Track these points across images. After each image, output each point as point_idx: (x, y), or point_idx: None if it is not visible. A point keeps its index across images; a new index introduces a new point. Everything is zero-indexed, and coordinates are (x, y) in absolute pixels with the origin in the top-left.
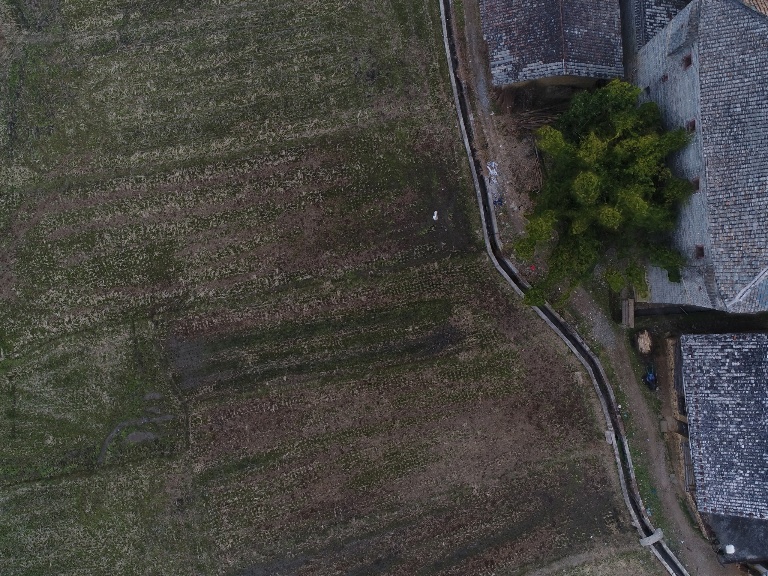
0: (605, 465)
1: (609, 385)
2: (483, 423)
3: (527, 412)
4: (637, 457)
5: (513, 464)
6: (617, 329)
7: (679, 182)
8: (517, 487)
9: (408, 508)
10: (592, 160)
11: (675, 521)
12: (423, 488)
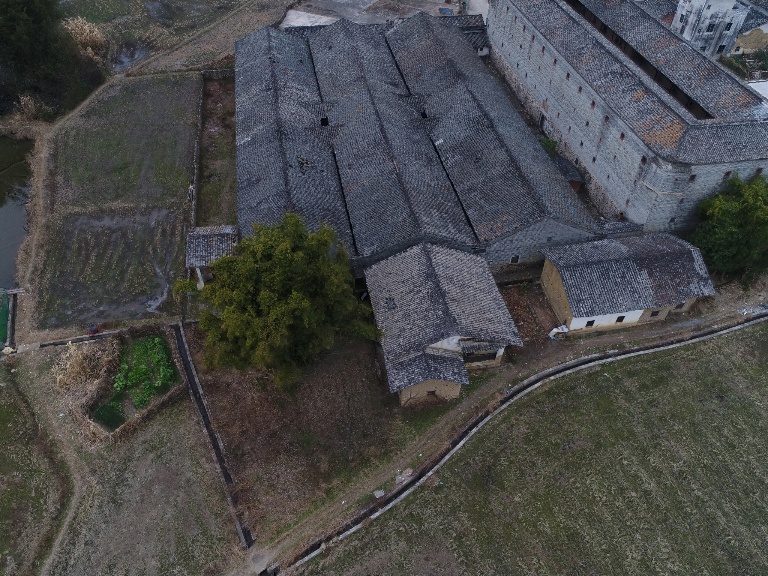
0: None
1: None
2: None
3: None
4: None
5: None
6: None
7: (757, 180)
8: None
9: None
10: None
11: None
12: None
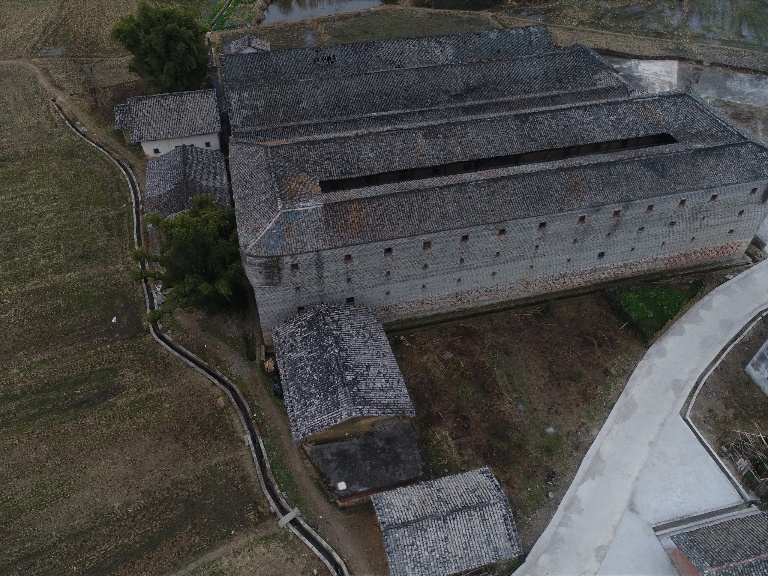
0: (244, 464)
1: (245, 401)
2: (133, 450)
3: (174, 435)
4: (272, 452)
5: (158, 479)
6: (252, 364)
7: None
8: (159, 497)
9: (43, 538)
10: (176, 220)
11: (312, 499)
12: (64, 516)
